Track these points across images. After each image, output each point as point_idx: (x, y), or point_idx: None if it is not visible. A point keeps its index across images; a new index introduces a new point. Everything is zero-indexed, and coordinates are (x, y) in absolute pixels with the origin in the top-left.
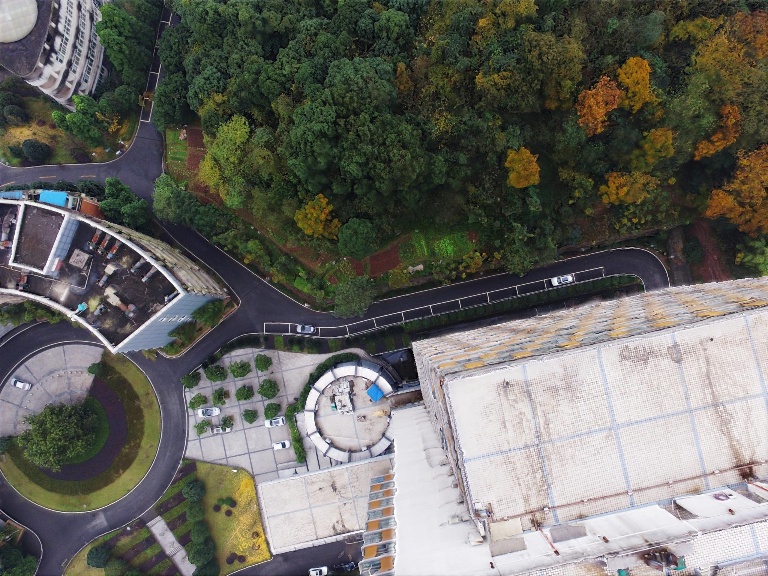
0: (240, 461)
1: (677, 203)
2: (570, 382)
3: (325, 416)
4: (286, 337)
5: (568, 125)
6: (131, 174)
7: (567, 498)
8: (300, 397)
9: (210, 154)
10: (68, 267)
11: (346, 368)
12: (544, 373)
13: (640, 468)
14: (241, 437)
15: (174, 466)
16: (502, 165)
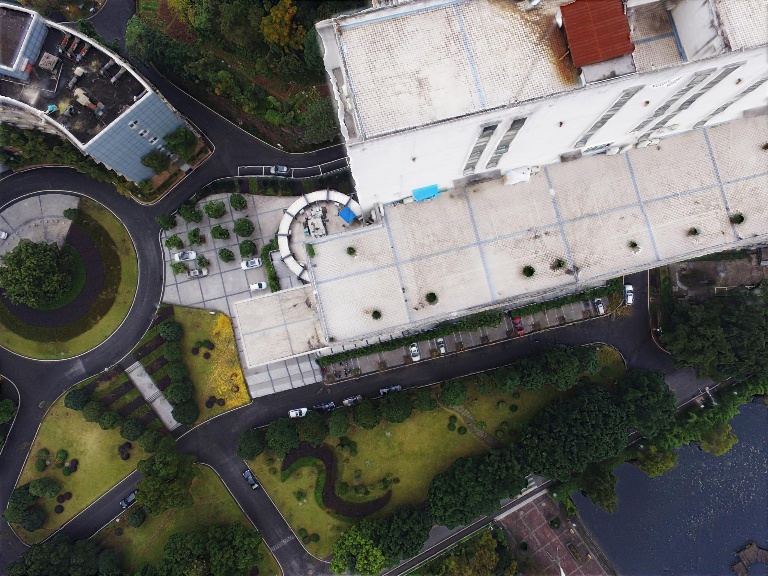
0: (217, 304)
1: None
2: None
3: (299, 242)
4: (260, 179)
5: None
6: (105, 31)
7: None
8: None
9: None
10: (38, 72)
11: (318, 193)
12: None
13: None
14: (218, 281)
15: (151, 311)
16: None
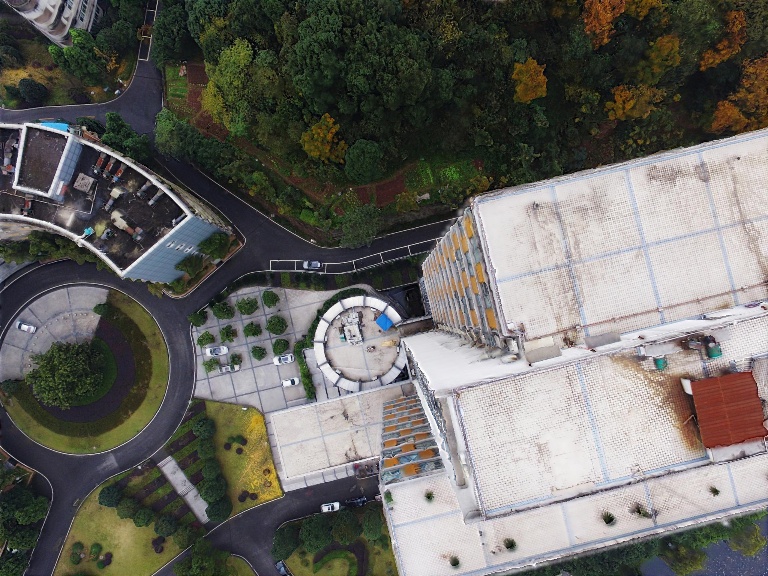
0: (249, 399)
1: (681, 126)
2: (599, 203)
3: (334, 348)
4: (293, 274)
5: (575, 33)
6: (131, 114)
7: (598, 317)
8: (308, 333)
9: (213, 81)
10: (73, 192)
11: (354, 299)
12: (573, 194)
13: (670, 286)
14: (250, 375)
15: (183, 406)
16: (509, 80)
